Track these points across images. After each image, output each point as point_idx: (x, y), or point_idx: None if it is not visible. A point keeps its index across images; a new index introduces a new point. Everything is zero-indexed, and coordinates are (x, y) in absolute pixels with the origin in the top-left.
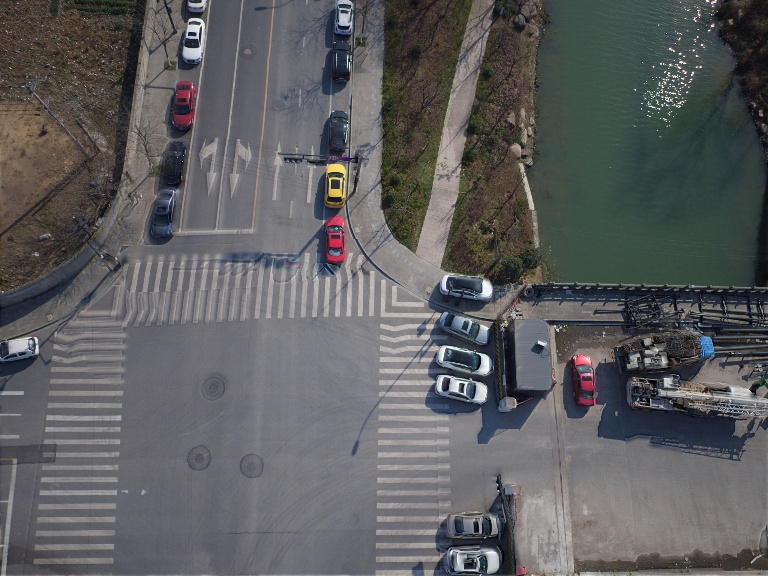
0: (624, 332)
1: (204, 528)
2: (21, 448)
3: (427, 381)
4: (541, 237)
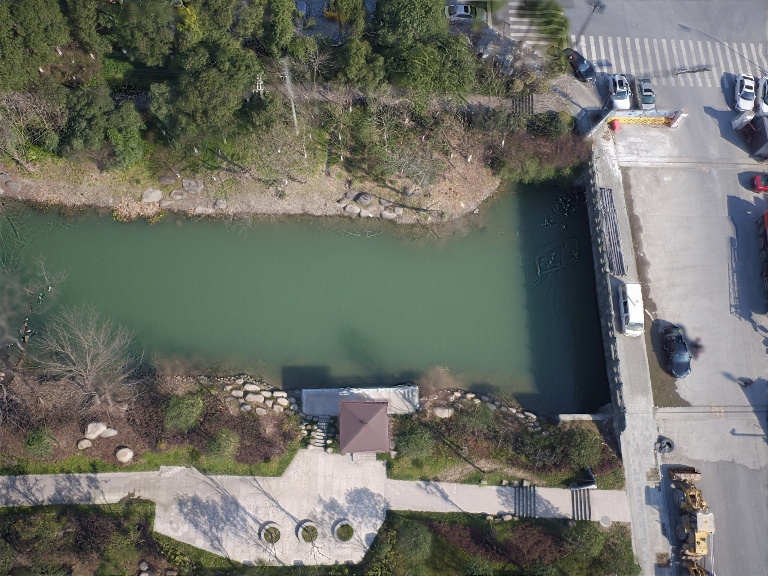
0: None
1: None
2: None
3: None
4: None
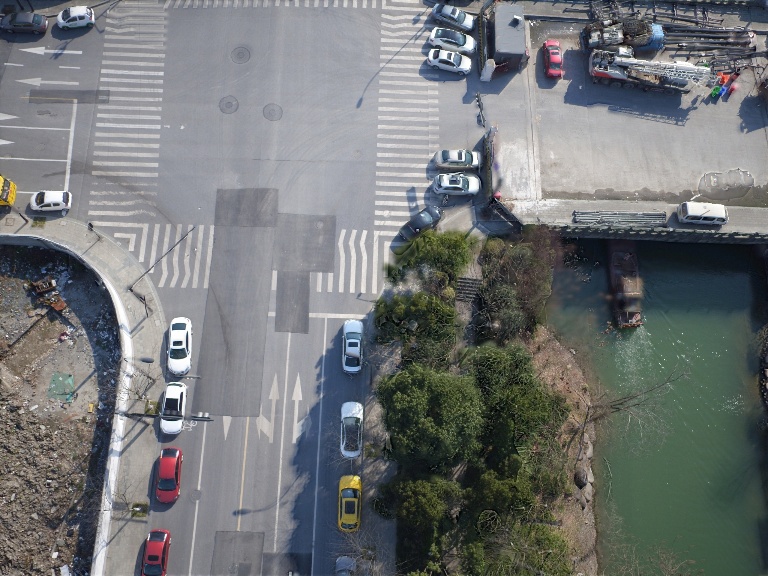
0: None
1: (233, 154)
2: (80, 92)
3: (420, 57)
4: None
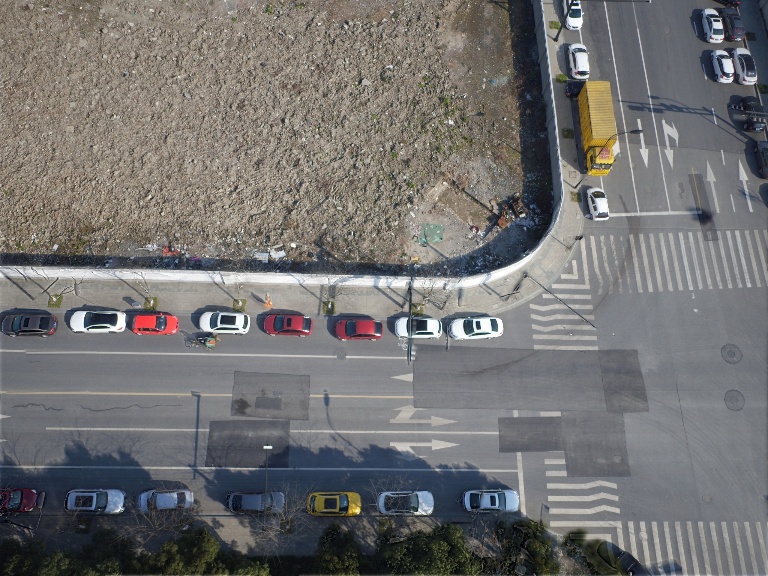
0: None
1: (677, 362)
2: (710, 215)
3: None
4: None
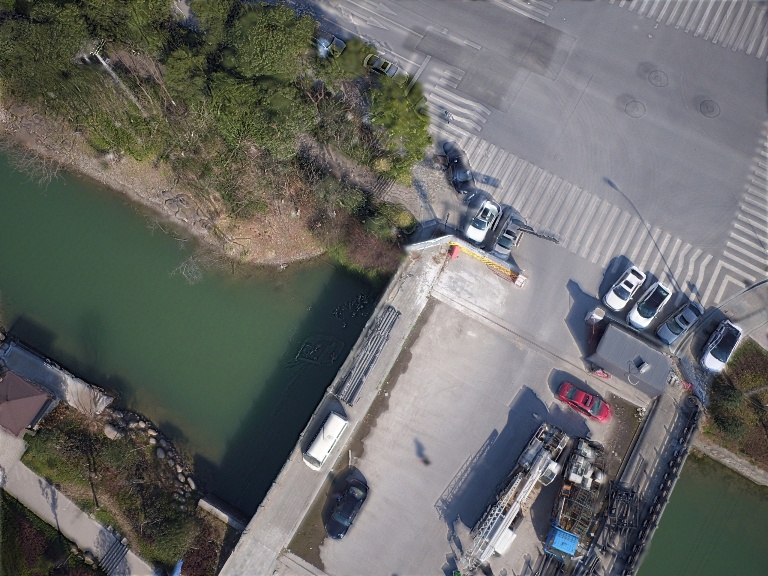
0: (608, 475)
1: (605, 62)
2: None
3: (643, 268)
4: (742, 459)
